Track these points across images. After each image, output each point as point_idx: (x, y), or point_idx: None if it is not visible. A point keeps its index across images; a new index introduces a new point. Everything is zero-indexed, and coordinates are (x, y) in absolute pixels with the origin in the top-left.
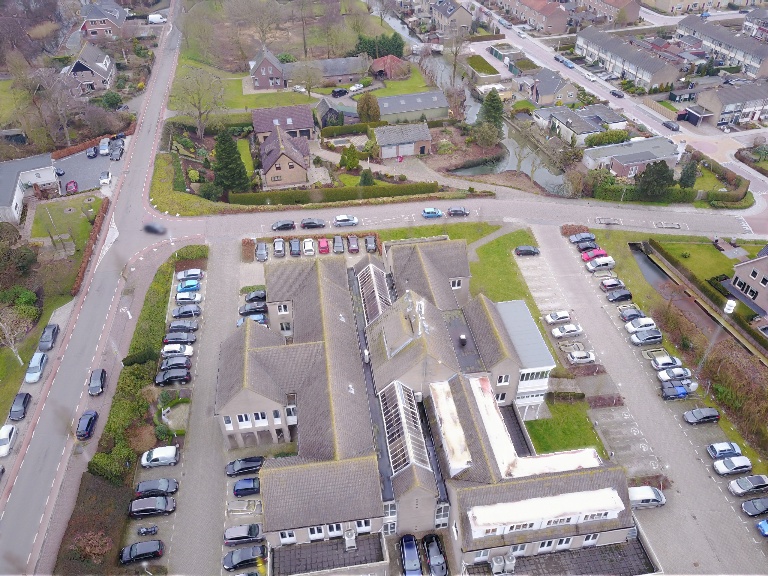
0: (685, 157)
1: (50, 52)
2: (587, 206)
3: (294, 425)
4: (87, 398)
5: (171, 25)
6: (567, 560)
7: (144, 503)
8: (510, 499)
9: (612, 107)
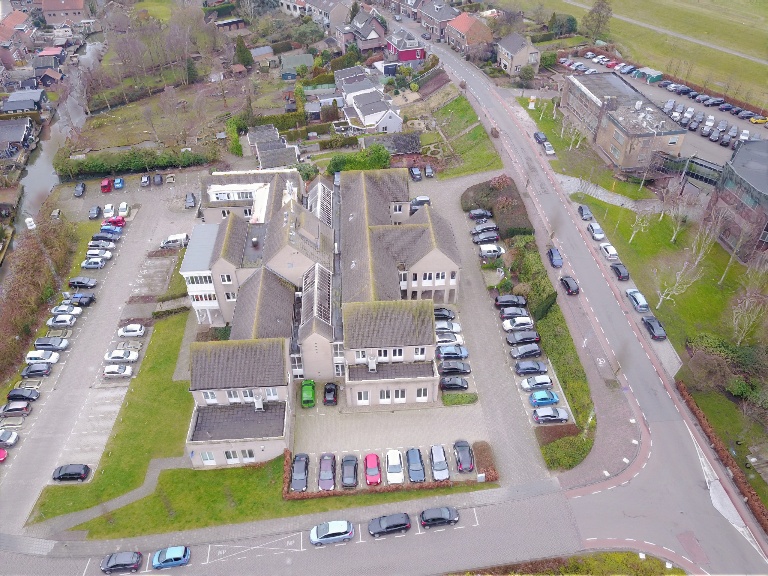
0: None
1: None
2: None
3: None
4: None
5: None
6: None
7: None
8: None
9: None
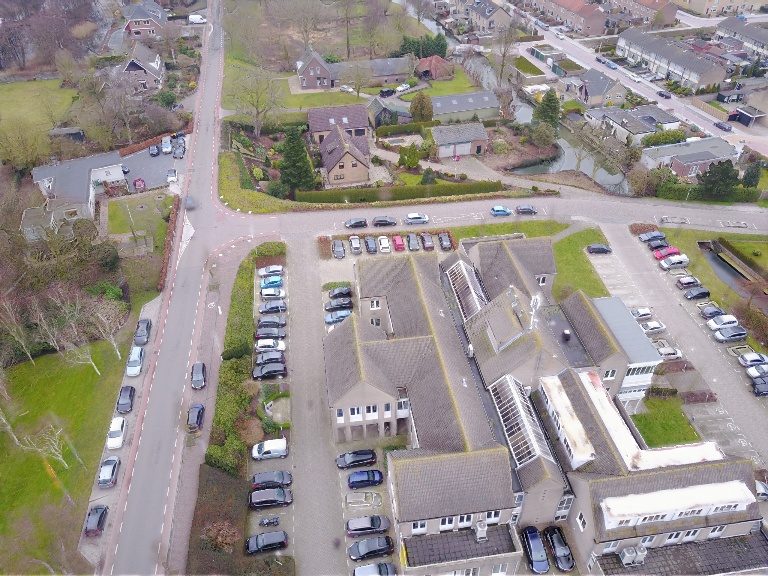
0: (743, 157)
1: (94, 52)
2: (652, 205)
3: (402, 418)
4: (190, 392)
5: (211, 25)
6: (694, 552)
7: (264, 494)
8: (641, 491)
9: (661, 108)
